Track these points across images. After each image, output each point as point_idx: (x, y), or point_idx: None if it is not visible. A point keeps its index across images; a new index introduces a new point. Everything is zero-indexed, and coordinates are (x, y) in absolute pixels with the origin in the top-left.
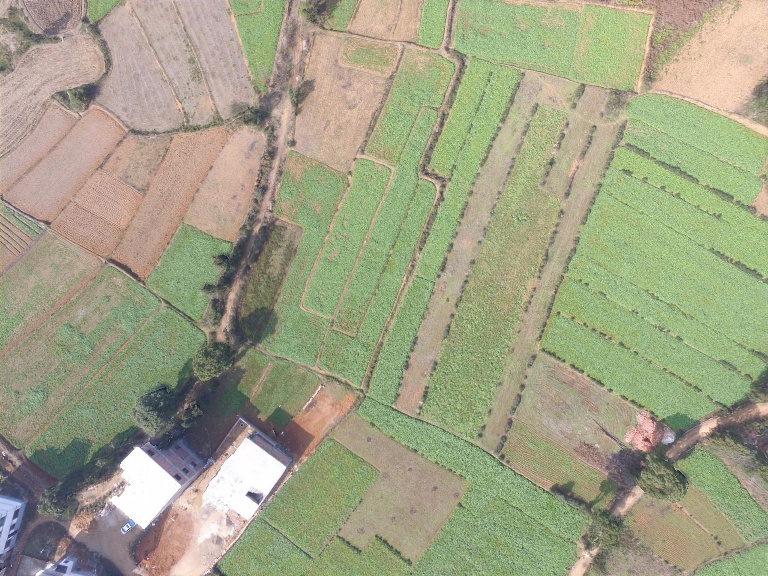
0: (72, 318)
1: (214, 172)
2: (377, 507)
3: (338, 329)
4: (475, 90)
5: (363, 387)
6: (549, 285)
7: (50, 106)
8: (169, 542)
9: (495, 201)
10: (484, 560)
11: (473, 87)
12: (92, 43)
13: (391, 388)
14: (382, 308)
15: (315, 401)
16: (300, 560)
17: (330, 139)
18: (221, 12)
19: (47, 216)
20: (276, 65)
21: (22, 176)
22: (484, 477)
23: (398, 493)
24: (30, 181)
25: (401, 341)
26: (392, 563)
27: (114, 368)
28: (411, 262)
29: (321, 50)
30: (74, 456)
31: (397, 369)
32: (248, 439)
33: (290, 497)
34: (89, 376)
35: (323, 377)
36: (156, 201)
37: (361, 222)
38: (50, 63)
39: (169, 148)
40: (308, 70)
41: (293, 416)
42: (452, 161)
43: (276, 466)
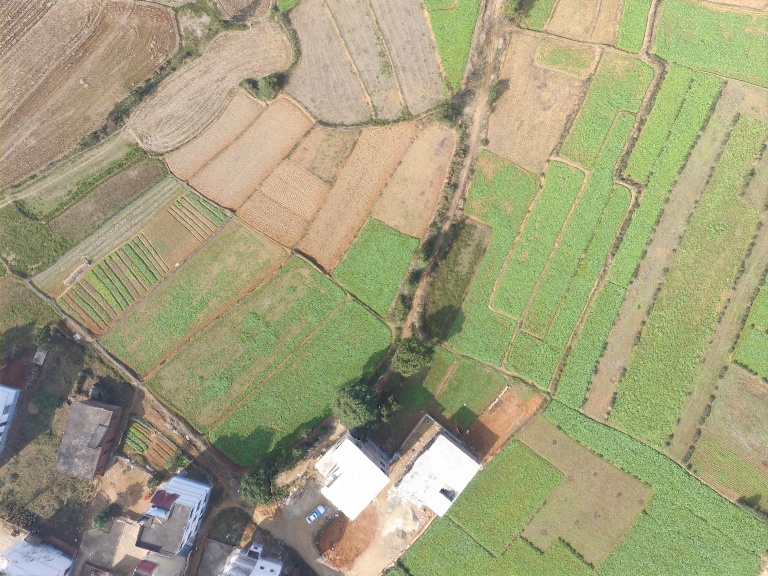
0: (258, 307)
1: (403, 167)
2: (561, 510)
3: (527, 331)
4: (675, 97)
5: (550, 390)
6: (744, 297)
7: (237, 93)
8: (354, 534)
9: (692, 210)
10: (667, 568)
11: (673, 93)
12: (280, 32)
13: (579, 392)
14: (572, 312)
15: (501, 401)
16: (483, 558)
17: (523, 139)
18: (414, 6)
19: (232, 203)
20: (471, 62)
21: (208, 162)
22: (670, 486)
23: (582, 497)
24: (216, 168)
25: (591, 346)
26: (575, 566)
27: (299, 358)
28: (603, 267)
29: (517, 49)
30: (257, 444)
31: (586, 373)
32: (443, 436)
33: (474, 495)
34: (274, 365)
35: (509, 378)
36: (343, 194)
37: (553, 224)
38: (237, 50)
39: (358, 141)
40: (503, 69)
41: (478, 415)
42: (649, 167)
43: (470, 464)
